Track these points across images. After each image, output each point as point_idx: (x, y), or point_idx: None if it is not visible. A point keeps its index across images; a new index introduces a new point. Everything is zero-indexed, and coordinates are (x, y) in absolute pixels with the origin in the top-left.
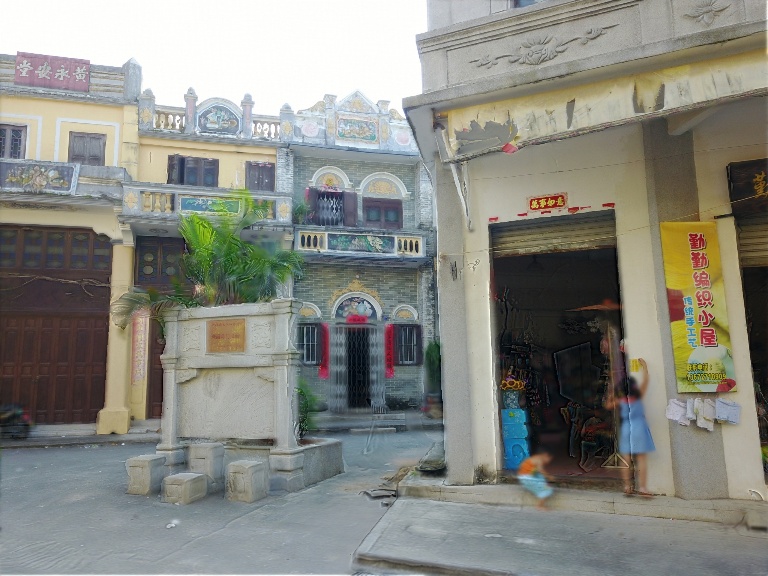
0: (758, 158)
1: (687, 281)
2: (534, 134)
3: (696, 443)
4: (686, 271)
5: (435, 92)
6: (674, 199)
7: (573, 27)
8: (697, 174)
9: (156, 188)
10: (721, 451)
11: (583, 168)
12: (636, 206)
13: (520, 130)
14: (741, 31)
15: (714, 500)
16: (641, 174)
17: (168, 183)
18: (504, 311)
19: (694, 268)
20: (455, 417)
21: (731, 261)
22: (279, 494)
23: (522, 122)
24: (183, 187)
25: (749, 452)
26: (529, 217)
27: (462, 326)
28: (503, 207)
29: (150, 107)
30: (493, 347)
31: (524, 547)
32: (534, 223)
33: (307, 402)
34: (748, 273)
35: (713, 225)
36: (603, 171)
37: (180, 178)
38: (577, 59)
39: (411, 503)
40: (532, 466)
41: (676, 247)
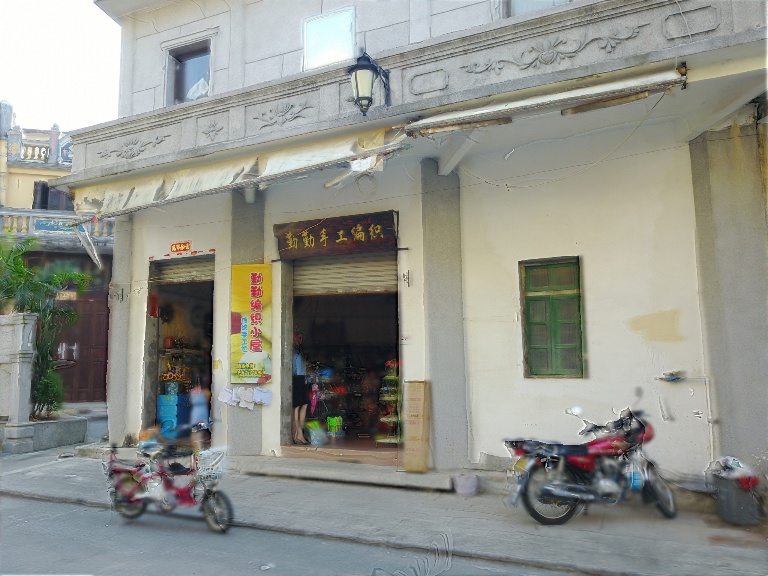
0: (286, 222)
1: (246, 306)
2: (107, 211)
3: (241, 418)
4: (246, 299)
5: (63, 177)
6: (245, 248)
7: (149, 134)
8: (265, 230)
9: (13, 212)
10: (260, 423)
11: (194, 224)
12: (226, 252)
13: (103, 207)
14: (206, 151)
15: (246, 456)
16: (230, 229)
17: (33, 205)
18: (156, 324)
19: (251, 297)
20: (113, 400)
21: (277, 292)
22: (4, 455)
23: (106, 201)
24: (37, 211)
25: (274, 424)
26: (170, 257)
27: (124, 335)
28: (156, 249)
29: (18, 141)
30: (145, 350)
31: (72, 481)
32: (180, 261)
33: (56, 389)
34: (297, 300)
35: (268, 267)
36: (209, 226)
37: (45, 201)
38: (149, 157)
39: (71, 459)
40: (171, 435)
41: (240, 282)
